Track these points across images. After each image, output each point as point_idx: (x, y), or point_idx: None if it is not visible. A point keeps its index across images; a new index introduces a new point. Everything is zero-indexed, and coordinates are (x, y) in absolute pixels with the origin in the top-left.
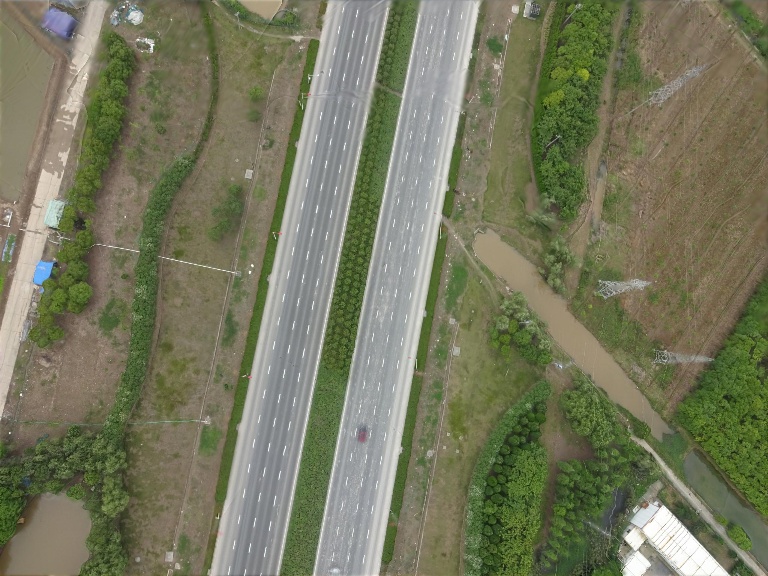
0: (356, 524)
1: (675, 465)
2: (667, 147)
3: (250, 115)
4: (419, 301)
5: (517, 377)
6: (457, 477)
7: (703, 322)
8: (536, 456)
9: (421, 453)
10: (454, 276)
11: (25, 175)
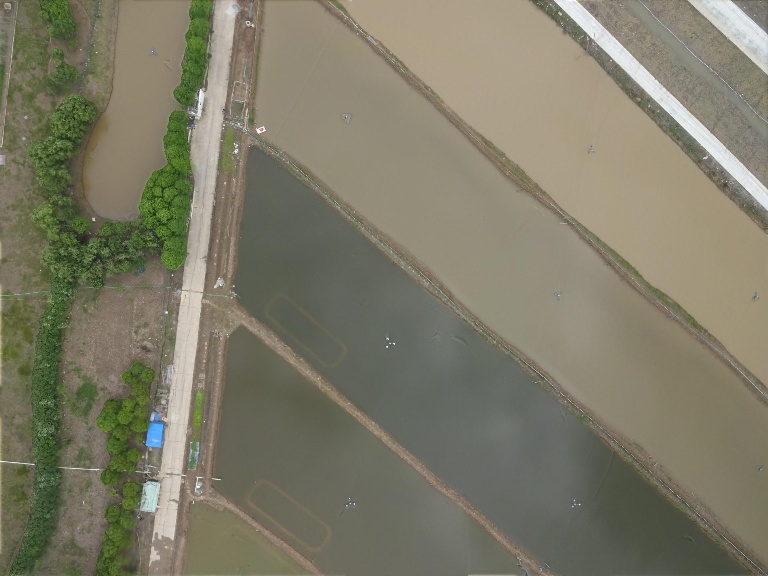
0: None
1: None
2: None
3: None
4: None
5: None
6: None
7: None
8: None
9: None
10: None
11: (187, 532)
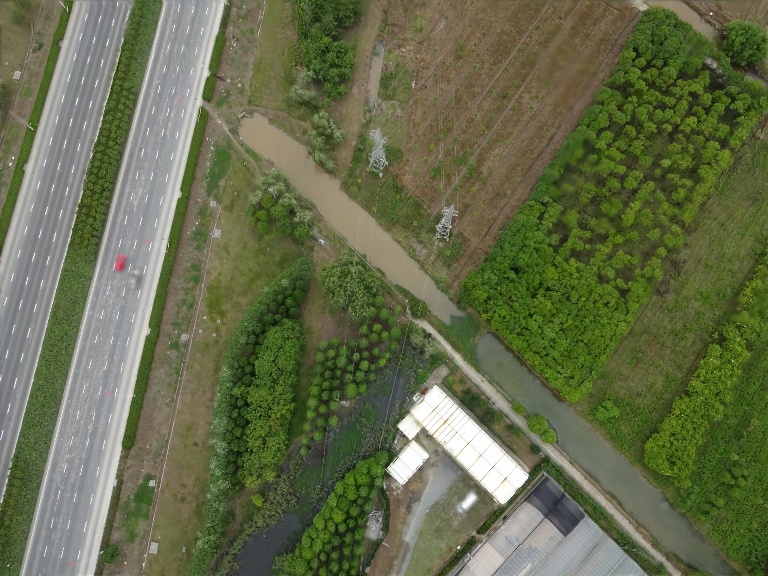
0: (98, 408)
1: (465, 349)
2: (447, 20)
3: (7, 15)
4: (176, 183)
5: (281, 257)
6: (213, 362)
7: (494, 195)
8: (284, 330)
9: (174, 337)
10: (216, 159)
11: None
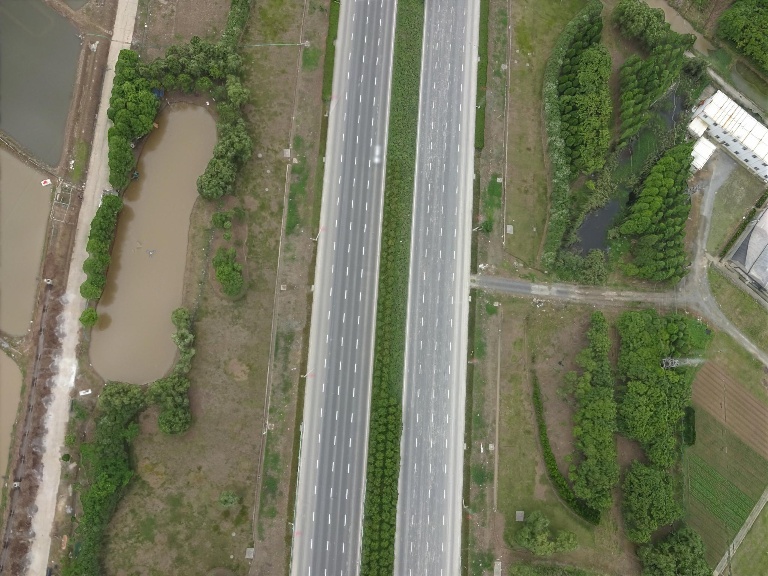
0: (448, 120)
1: (723, 74)
2: None
3: None
4: None
5: (571, 4)
6: (531, 86)
7: None
8: (599, 48)
9: (496, 66)
10: None
11: None
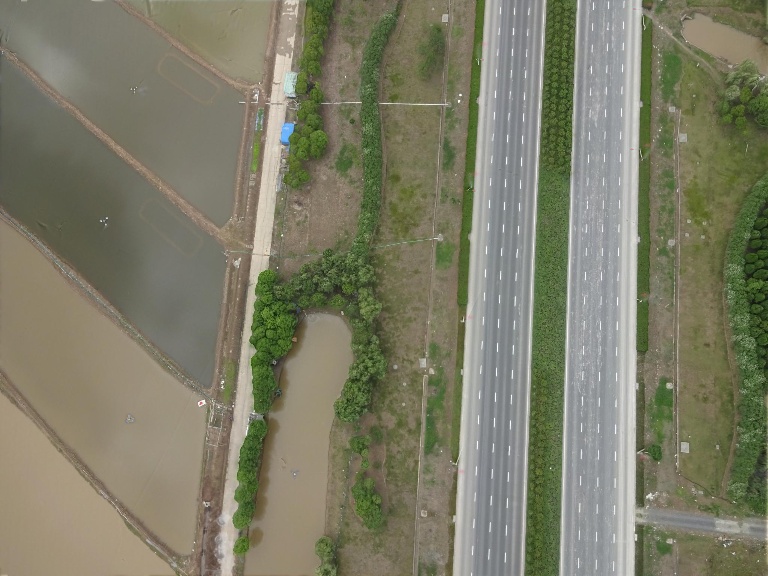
0: (602, 317)
1: None
2: None
3: None
4: (632, 94)
5: (760, 152)
6: (707, 263)
7: None
8: None
9: (661, 243)
10: (666, 65)
11: (265, 60)
